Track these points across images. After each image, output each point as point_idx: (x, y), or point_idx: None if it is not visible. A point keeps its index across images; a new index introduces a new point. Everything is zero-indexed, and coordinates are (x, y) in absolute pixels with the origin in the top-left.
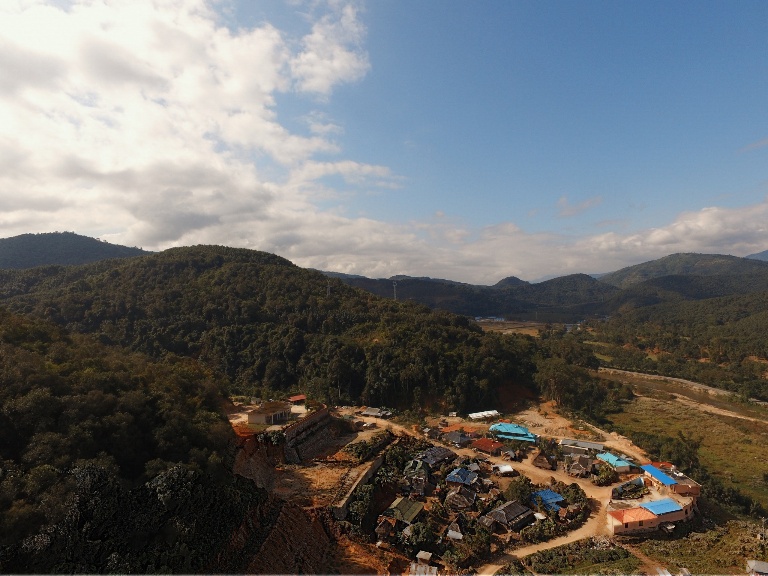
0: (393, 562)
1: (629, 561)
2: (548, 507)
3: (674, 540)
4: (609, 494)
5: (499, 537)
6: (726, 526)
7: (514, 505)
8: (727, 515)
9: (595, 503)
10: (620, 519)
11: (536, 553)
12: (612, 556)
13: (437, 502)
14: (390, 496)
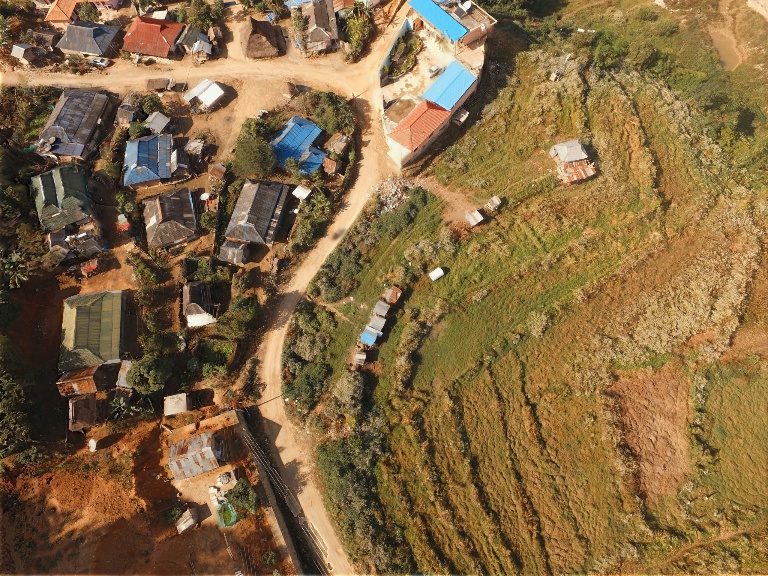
0: (136, 464)
1: (430, 210)
2: (307, 168)
3: (467, 132)
4: (377, 83)
5: (264, 280)
6: (516, 69)
7: (260, 197)
8: (514, 44)
9: (361, 108)
10: (408, 146)
11: (320, 271)
12: (410, 214)
13: (137, 254)
14: (48, 293)
